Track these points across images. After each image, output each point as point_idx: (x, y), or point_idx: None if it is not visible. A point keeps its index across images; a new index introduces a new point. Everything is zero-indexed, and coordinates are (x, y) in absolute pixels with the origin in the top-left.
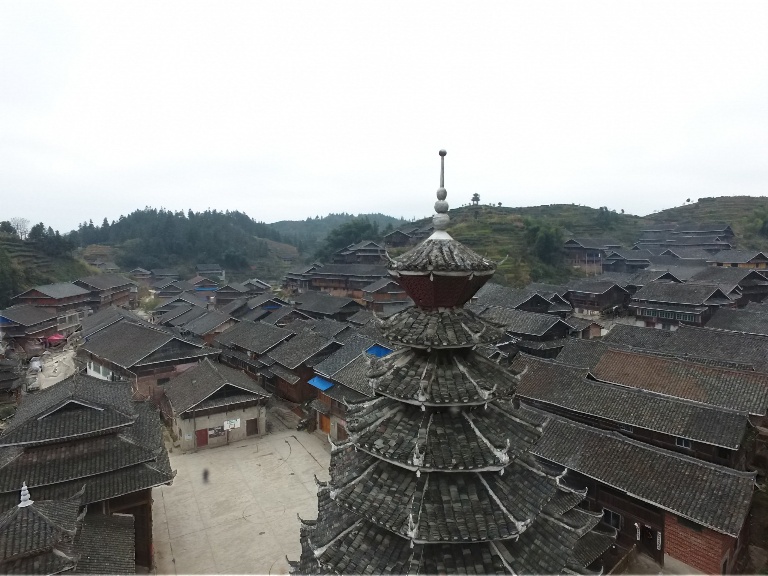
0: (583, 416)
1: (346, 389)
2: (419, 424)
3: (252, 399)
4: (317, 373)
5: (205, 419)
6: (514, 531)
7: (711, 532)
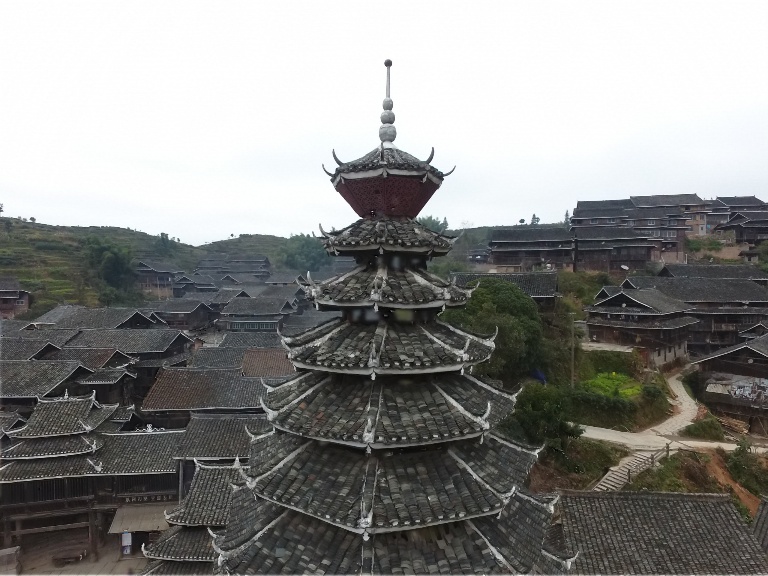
0: (250, 412)
1: None
2: (424, 333)
3: None
4: None
5: None
6: None
7: None
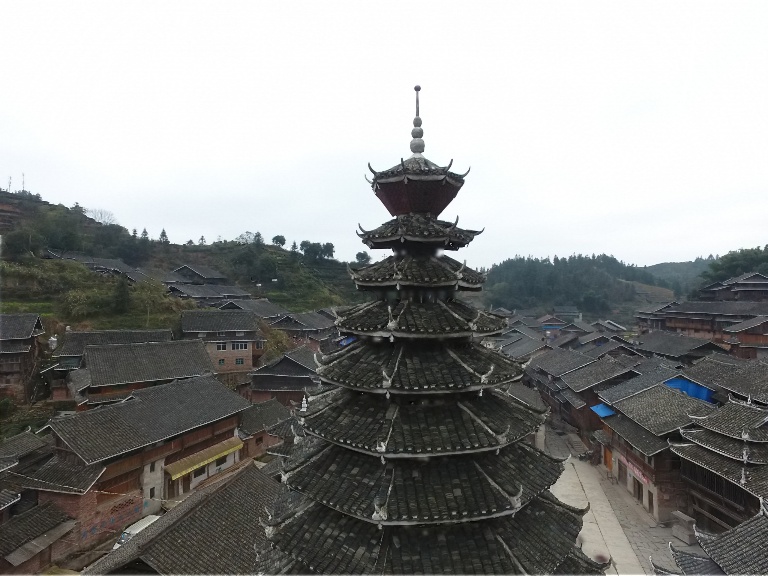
0: None
1: (627, 420)
2: None
3: None
4: (601, 399)
5: None
6: (379, 384)
7: None
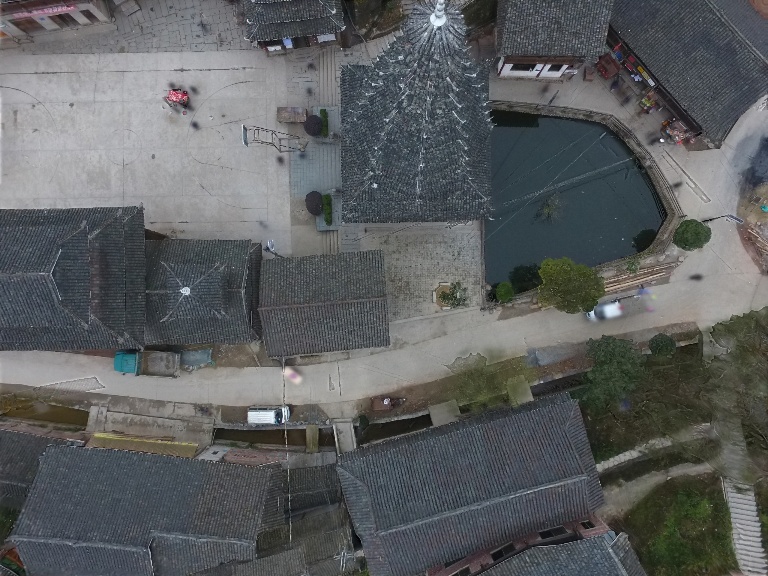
0: None
1: None
2: None
3: None
4: None
5: None
6: None
7: None
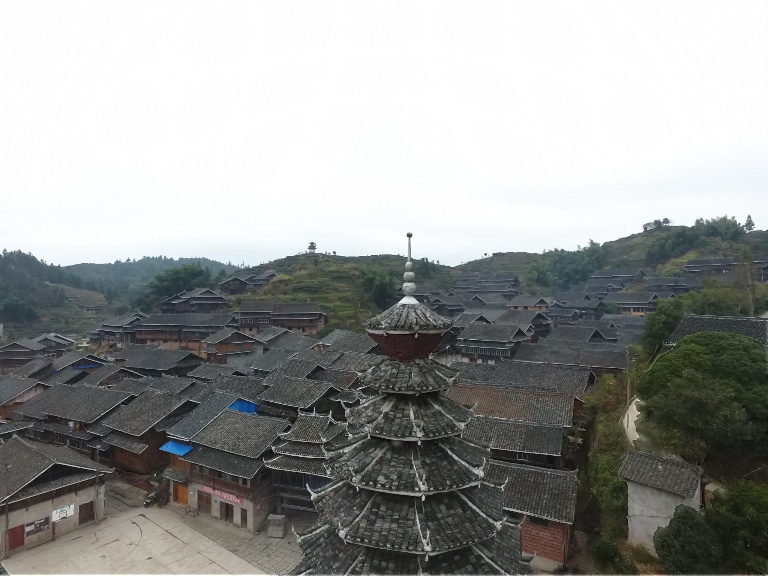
0: None
1: (209, 451)
2: (411, 458)
3: (88, 478)
4: (171, 437)
5: (22, 512)
6: (495, 530)
7: (554, 524)
